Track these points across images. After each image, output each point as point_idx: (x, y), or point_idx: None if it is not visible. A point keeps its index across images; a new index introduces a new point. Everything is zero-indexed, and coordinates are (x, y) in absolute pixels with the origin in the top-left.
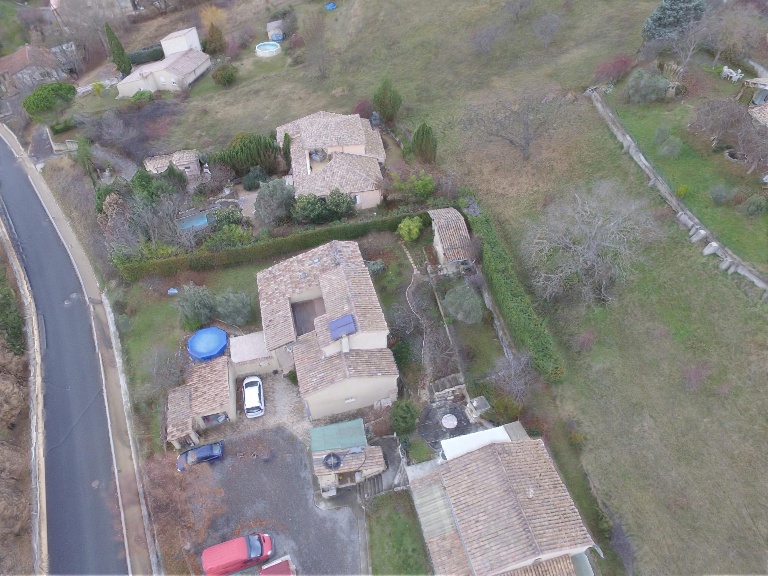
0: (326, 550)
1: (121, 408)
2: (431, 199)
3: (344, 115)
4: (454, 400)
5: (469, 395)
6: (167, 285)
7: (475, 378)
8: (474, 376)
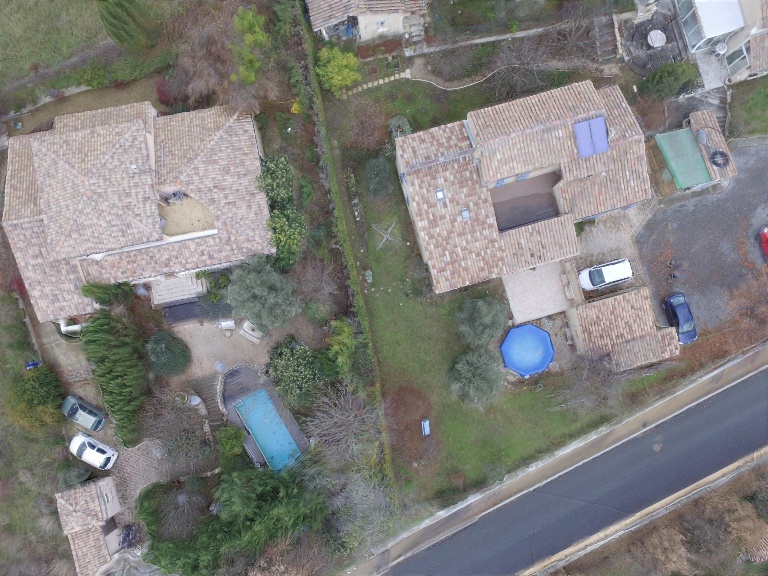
0: (765, 176)
1: (563, 456)
2: (279, 25)
3: (7, 182)
4: (621, 35)
5: (627, 12)
6: (412, 441)
7: (606, 1)
8: (600, 4)
